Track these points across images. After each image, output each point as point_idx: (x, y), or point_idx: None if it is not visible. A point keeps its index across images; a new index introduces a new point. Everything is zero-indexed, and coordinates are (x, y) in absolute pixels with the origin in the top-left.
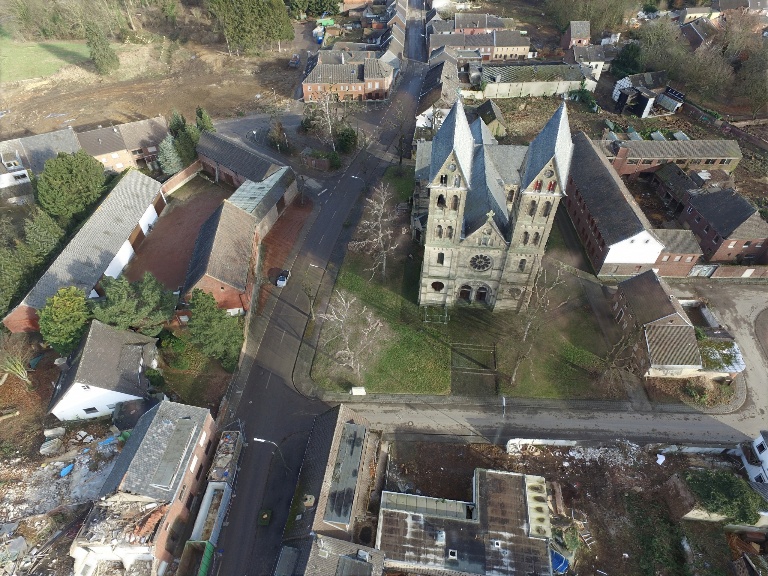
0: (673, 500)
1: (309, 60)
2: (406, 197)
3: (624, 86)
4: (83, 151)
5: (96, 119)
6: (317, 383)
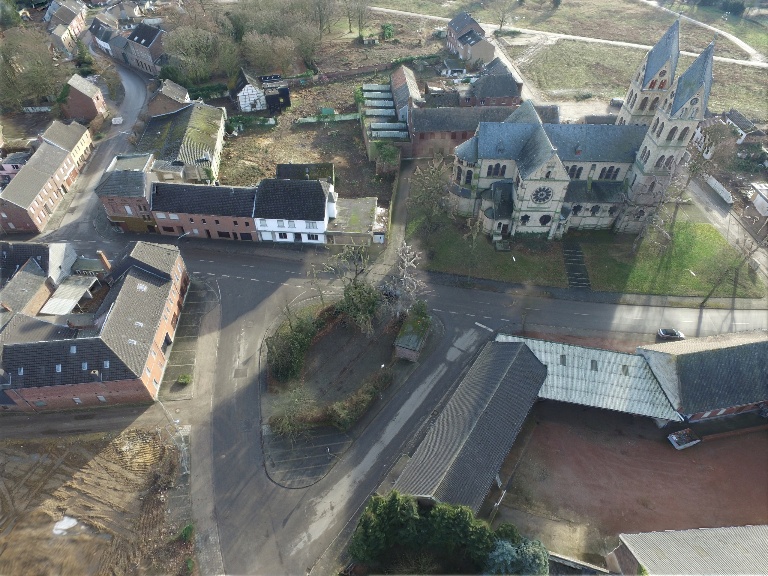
0: (724, 151)
1: (6, 378)
2: (484, 245)
3: (250, 94)
4: None
5: None
6: (765, 292)
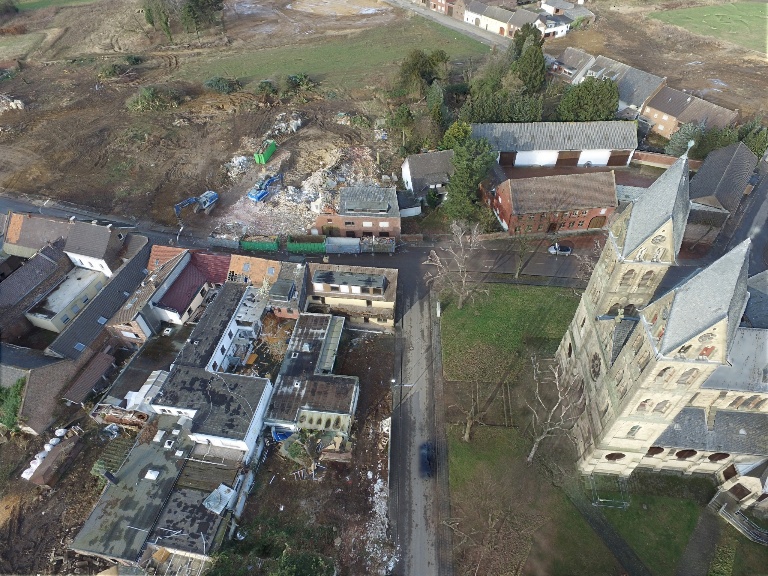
0: None
1: None
2: None
3: None
4: (615, 84)
5: (733, 100)
6: None
